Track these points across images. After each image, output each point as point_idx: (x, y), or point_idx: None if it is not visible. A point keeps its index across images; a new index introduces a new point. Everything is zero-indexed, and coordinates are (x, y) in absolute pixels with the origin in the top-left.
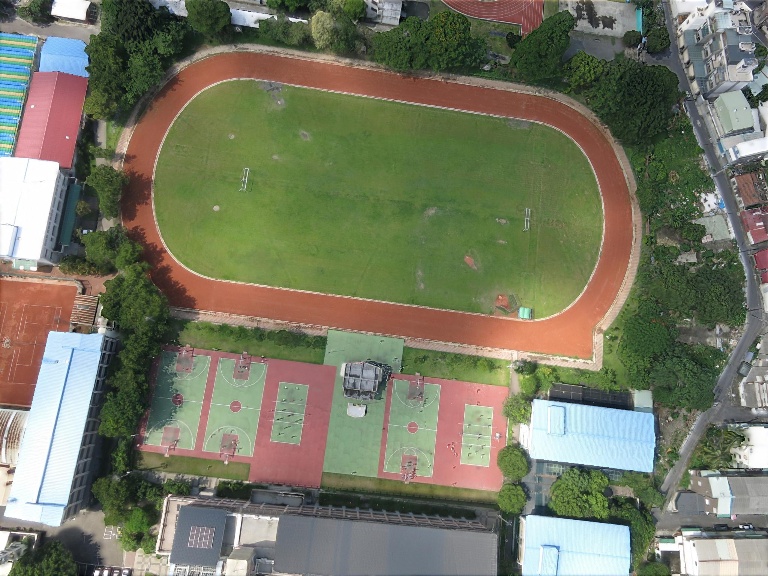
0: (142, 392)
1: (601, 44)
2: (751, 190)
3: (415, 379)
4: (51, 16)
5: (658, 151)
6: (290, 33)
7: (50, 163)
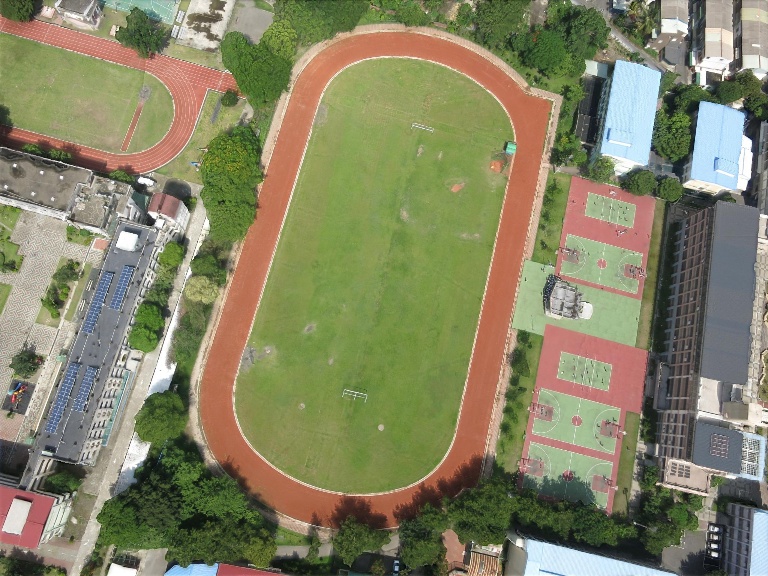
0: (572, 506)
1: (242, 18)
2: None
3: (561, 255)
4: None
5: None
6: (198, 328)
7: None
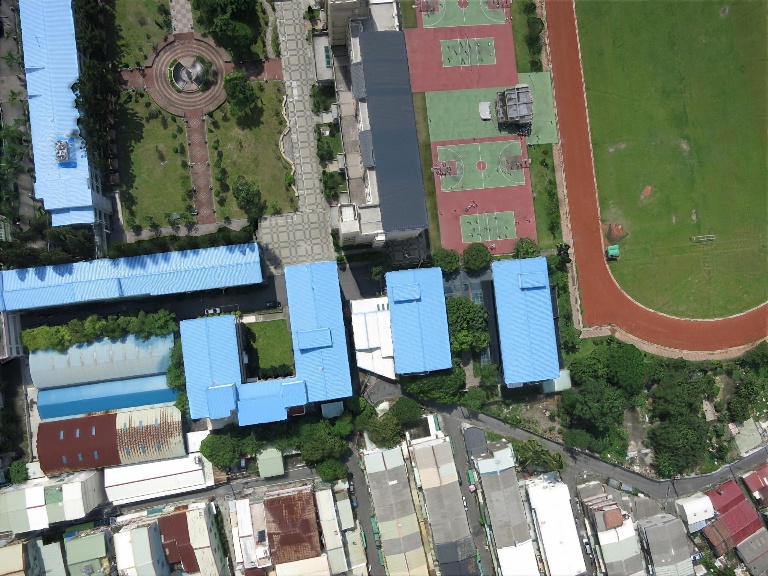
0: None
1: None
2: None
3: None
4: None
5: None
6: None
7: None
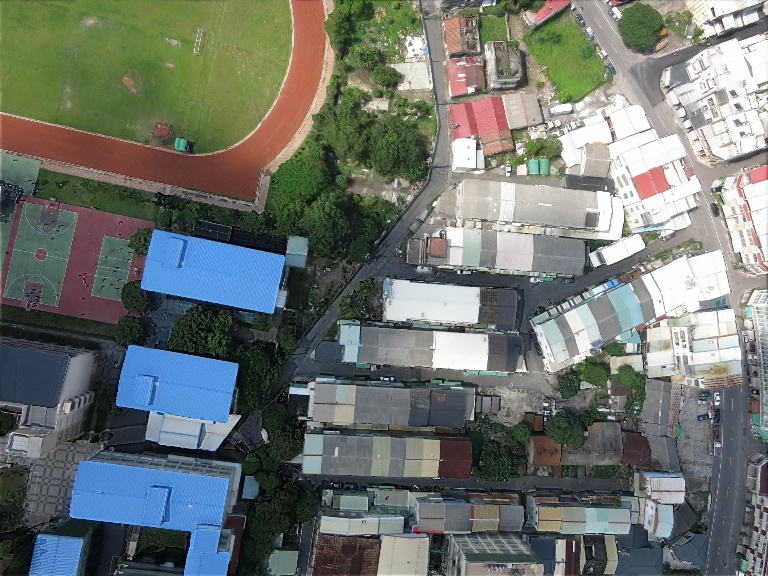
0: None
1: None
2: (457, 36)
3: None
4: None
5: None
6: None
7: None
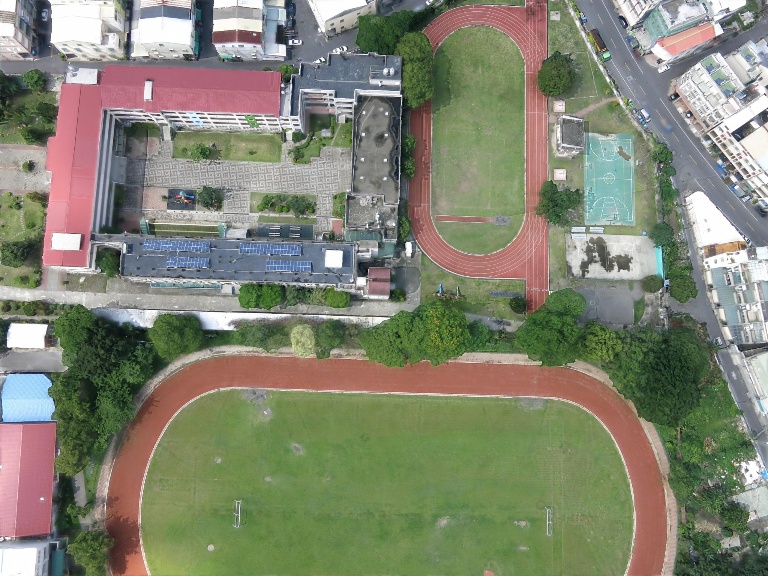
0: None
1: (617, 291)
2: None
3: None
4: (7, 347)
5: (690, 416)
6: (268, 345)
7: (26, 550)
